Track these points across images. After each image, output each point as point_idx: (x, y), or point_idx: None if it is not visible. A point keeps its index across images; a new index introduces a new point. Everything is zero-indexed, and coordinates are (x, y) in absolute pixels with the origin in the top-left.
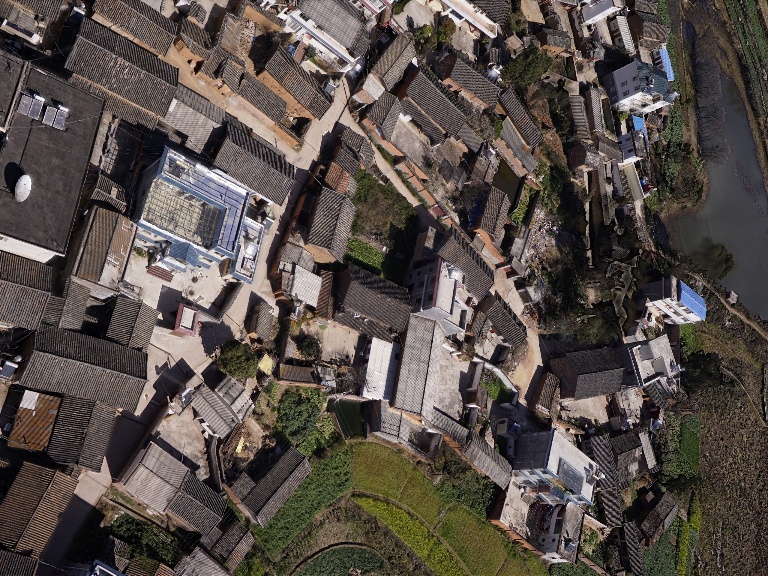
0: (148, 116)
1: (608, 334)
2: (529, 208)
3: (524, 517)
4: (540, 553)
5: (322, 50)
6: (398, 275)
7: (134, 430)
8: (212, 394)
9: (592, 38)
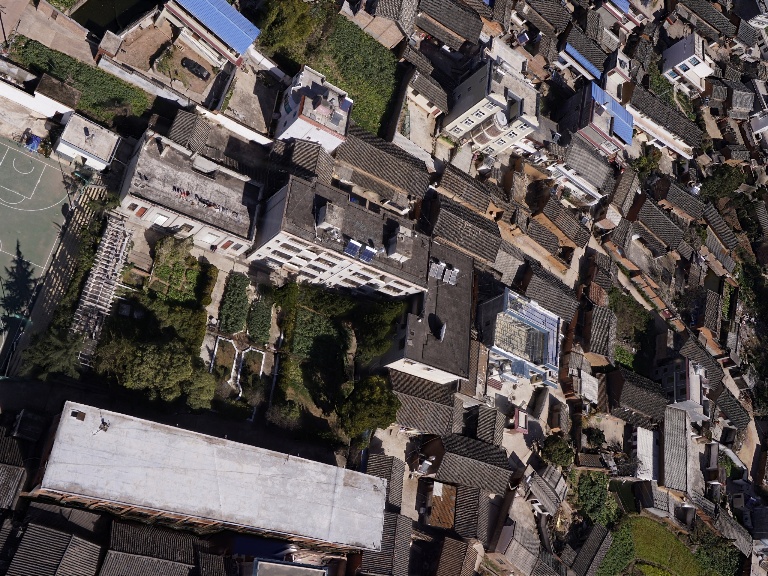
0: (481, 262)
1: None
2: (731, 303)
3: None
4: None
5: (574, 189)
6: (645, 372)
7: (492, 510)
8: (541, 480)
9: (760, 145)
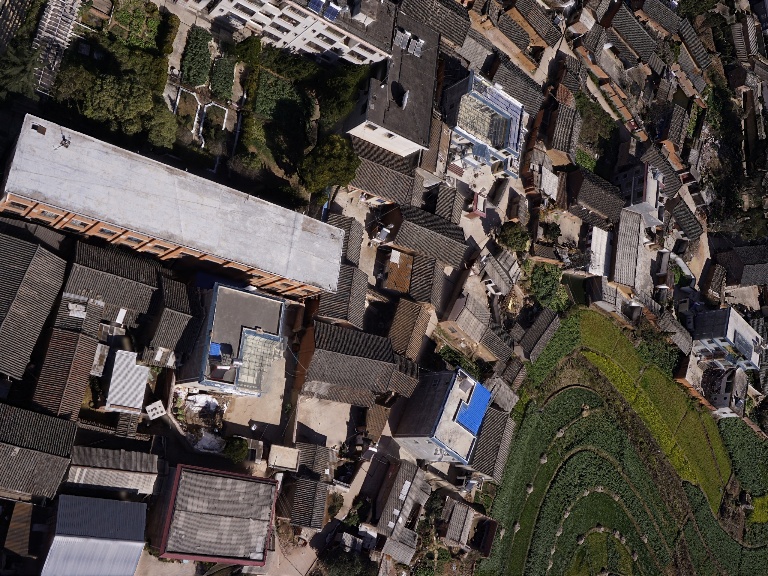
0: (448, 46)
1: (759, 235)
2: (697, 124)
3: (699, 380)
4: (714, 408)
5: None
6: (605, 178)
7: (447, 286)
8: (496, 262)
9: None
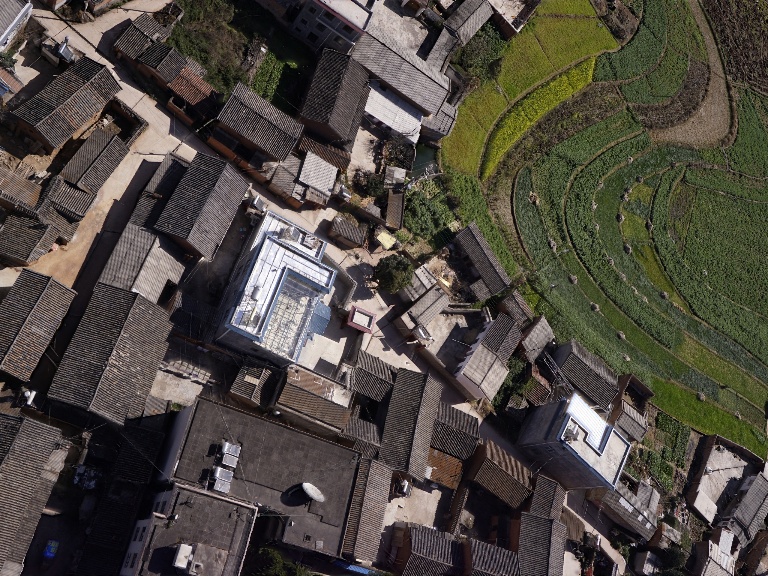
0: None
1: None
2: None
3: None
4: None
5: None
6: (289, 42)
7: None
8: (417, 305)
9: None
